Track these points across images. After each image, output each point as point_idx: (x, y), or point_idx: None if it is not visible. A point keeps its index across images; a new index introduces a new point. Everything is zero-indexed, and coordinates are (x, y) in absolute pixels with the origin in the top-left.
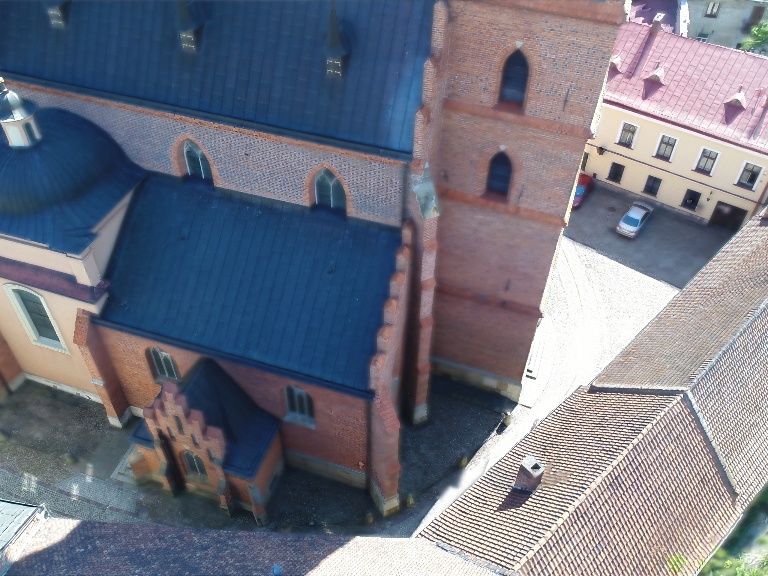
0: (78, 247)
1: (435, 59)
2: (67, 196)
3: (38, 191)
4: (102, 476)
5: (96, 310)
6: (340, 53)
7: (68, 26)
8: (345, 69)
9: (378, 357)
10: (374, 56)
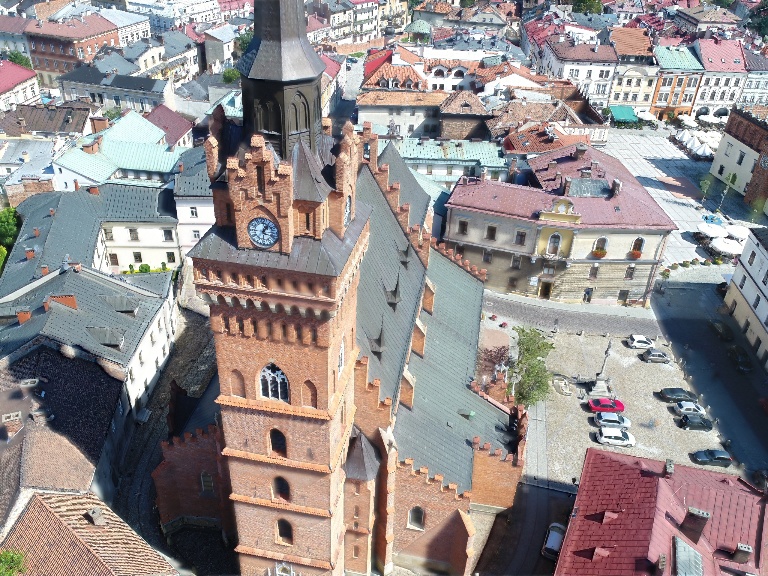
0: None
1: None
2: None
3: None
4: None
5: None
6: None
7: None
8: None
9: (166, 441)
10: None
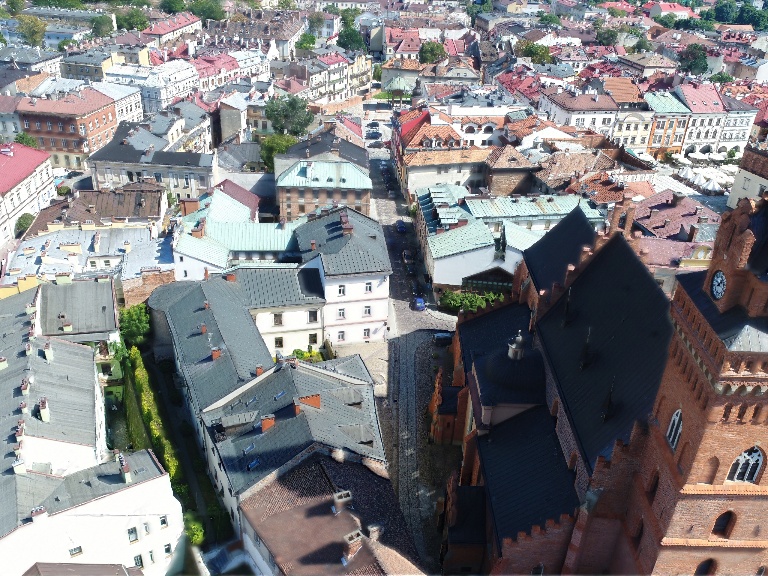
0: (486, 403)
1: (622, 442)
2: (505, 385)
3: (498, 375)
4: (432, 498)
5: (479, 433)
6: (605, 412)
7: (565, 329)
8: (607, 421)
9: (509, 538)
10: (618, 425)
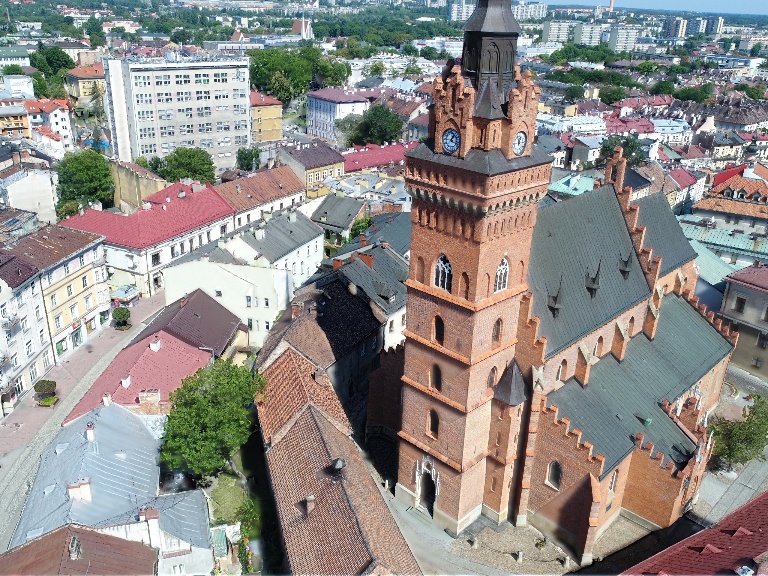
0: None
1: None
2: None
3: None
4: None
5: None
6: None
7: None
8: None
9: None
10: None
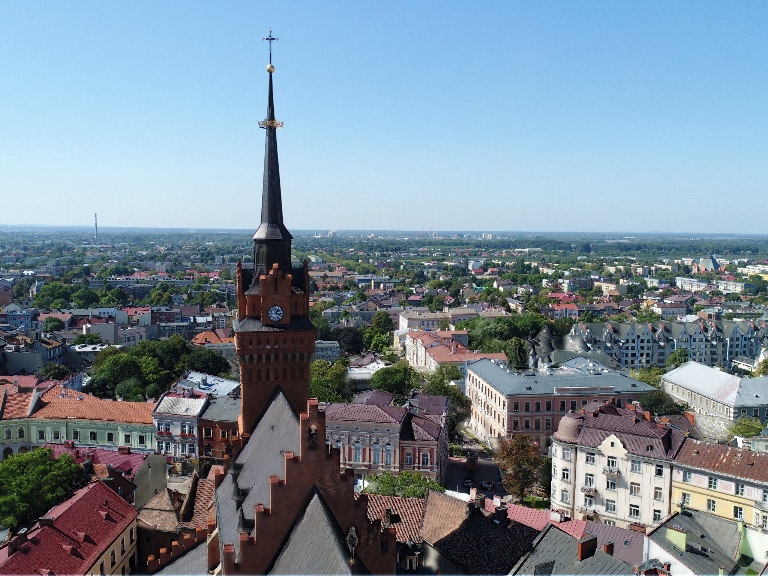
0: (429, 567)
1: None
2: None
3: None
4: None
5: None
6: None
7: None
8: None
9: None
10: None
